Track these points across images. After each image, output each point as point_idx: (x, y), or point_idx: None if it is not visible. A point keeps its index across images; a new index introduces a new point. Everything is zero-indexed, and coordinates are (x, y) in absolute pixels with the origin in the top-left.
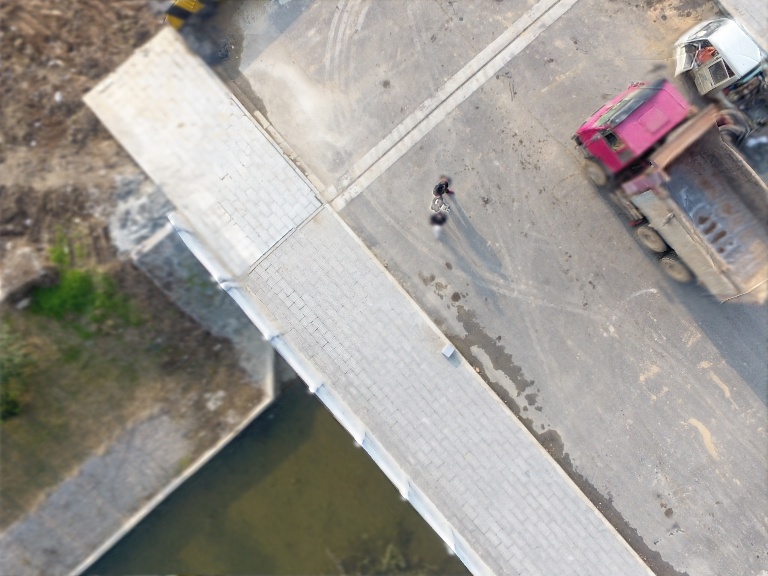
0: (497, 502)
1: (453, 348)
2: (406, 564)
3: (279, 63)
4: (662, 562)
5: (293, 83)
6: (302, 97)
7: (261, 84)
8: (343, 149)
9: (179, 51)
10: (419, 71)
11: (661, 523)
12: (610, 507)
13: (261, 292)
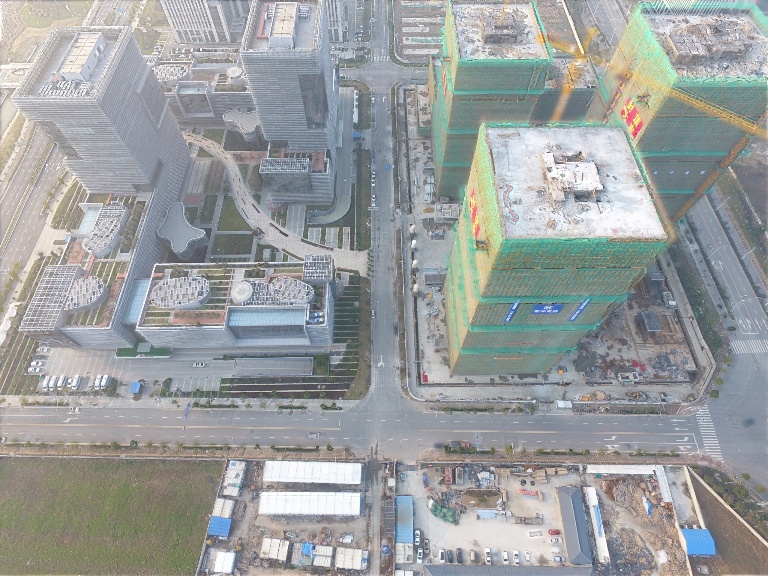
0: None
1: None
2: None
3: None
4: None
5: None
6: None
7: None
8: (2, 81)
9: None
10: (4, 77)
11: None
12: None
13: None
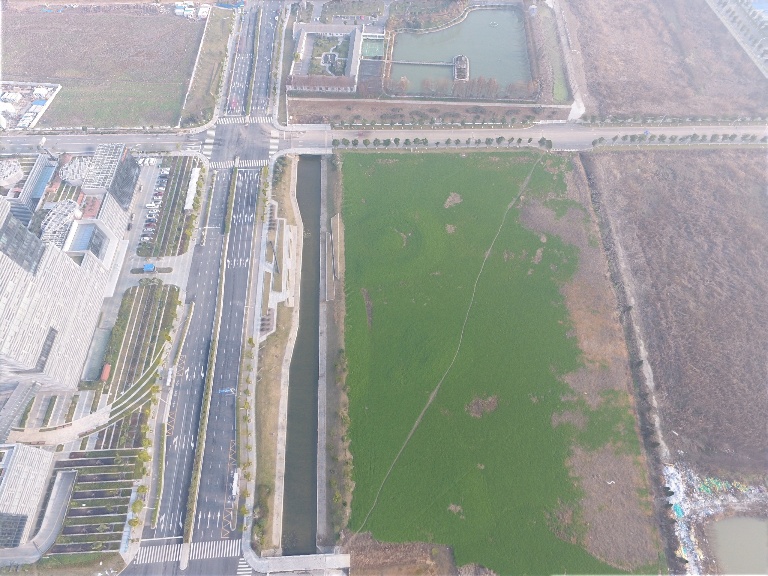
0: (293, 562)
1: (307, 570)
2: (292, 546)
3: (340, 575)
4: (277, 573)
5: (337, 574)
6: (335, 574)
7: (339, 571)
8: (329, 574)
9: (347, 566)
10: None
11: (280, 575)
12: (284, 572)
13: (323, 556)
